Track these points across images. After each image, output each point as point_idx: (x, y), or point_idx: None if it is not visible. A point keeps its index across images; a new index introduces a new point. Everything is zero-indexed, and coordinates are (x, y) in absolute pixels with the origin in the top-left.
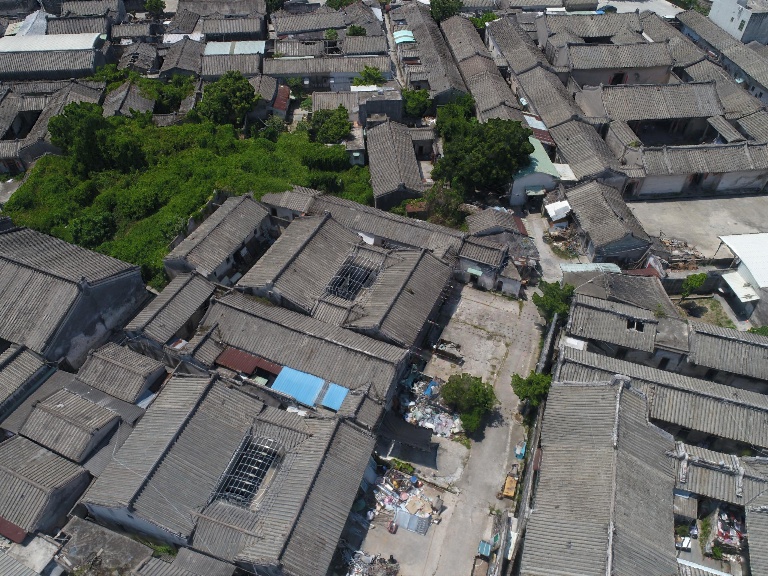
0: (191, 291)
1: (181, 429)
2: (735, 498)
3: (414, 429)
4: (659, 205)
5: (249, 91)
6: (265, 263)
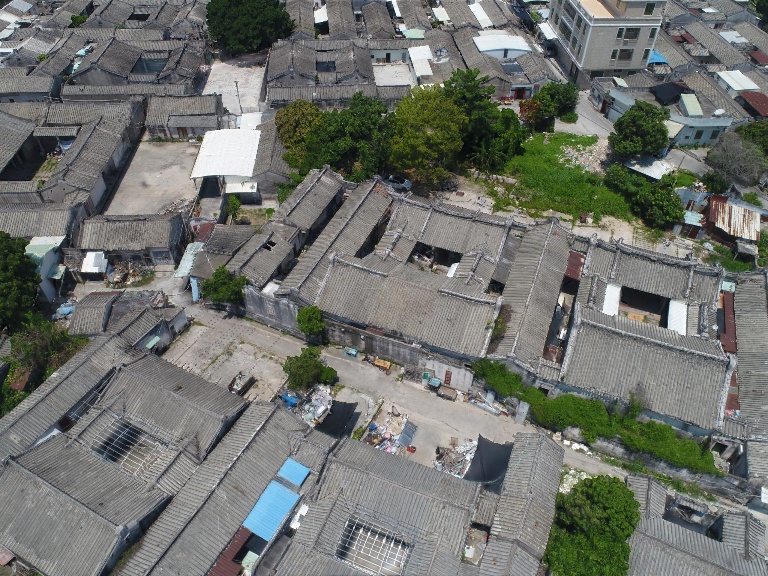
0: None
1: None
2: (413, 243)
3: (332, 415)
4: (114, 205)
5: None
6: (57, 553)
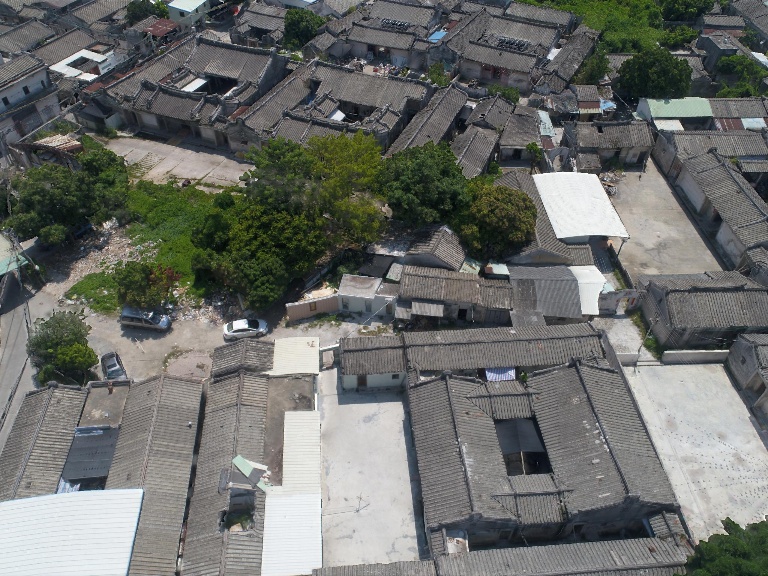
0: (494, 10)
1: (409, 5)
2: None
3: None
4: (671, 198)
5: (694, 3)
6: None
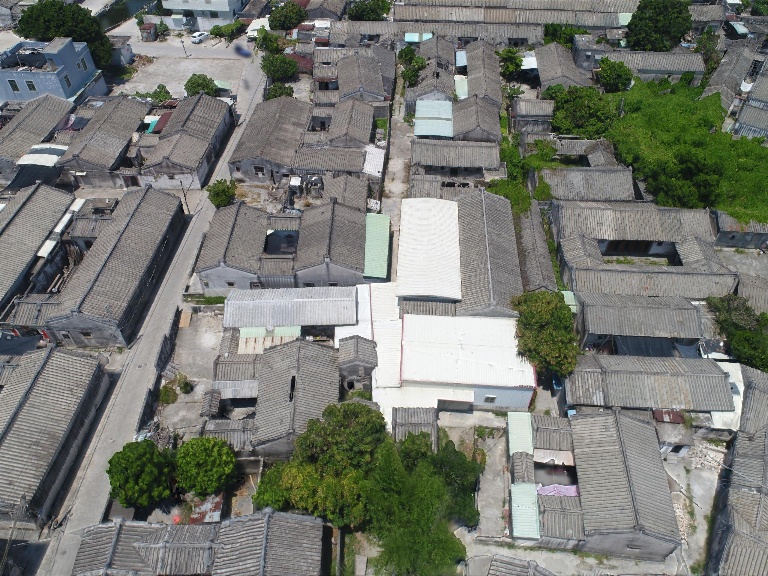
0: None
1: None
2: None
3: None
4: None
5: None
6: None
